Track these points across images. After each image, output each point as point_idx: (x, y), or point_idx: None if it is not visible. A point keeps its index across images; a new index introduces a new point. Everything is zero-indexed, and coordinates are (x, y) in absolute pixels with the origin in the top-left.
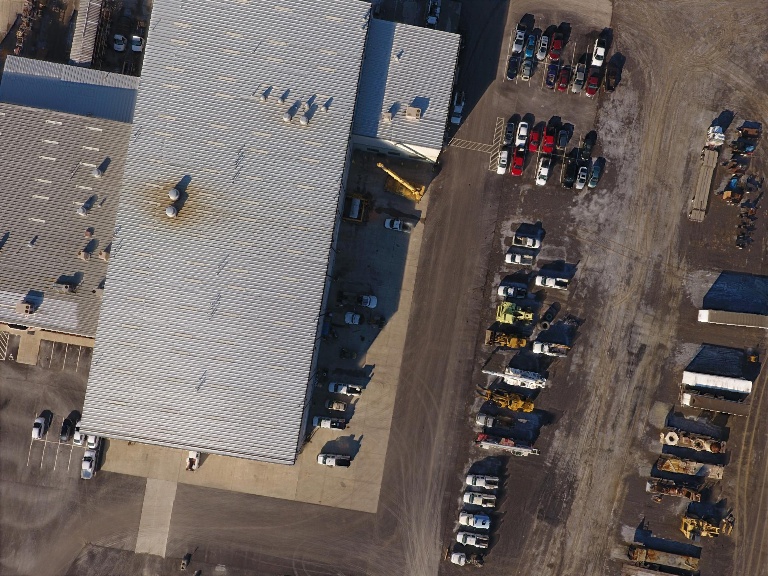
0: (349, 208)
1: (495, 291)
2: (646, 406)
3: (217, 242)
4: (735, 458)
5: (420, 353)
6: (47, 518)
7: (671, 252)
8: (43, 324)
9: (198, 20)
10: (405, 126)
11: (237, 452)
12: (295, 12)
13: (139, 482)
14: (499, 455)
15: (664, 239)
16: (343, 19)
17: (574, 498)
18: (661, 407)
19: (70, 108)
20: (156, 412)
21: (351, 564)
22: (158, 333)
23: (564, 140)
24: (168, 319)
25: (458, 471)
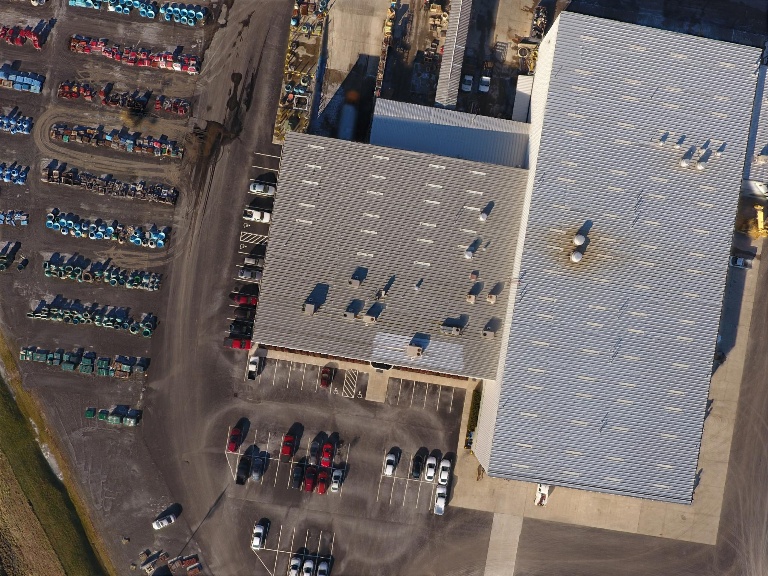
0: None
1: None
2: None
3: (617, 286)
4: None
5: (757, 387)
6: (396, 553)
7: None
8: (430, 366)
9: (598, 67)
10: None
11: (638, 492)
12: (690, 58)
13: (486, 517)
14: None
15: None
16: (736, 65)
17: None
18: None
19: (440, 151)
20: (560, 454)
21: None
22: (562, 376)
23: None
24: (571, 362)
25: None
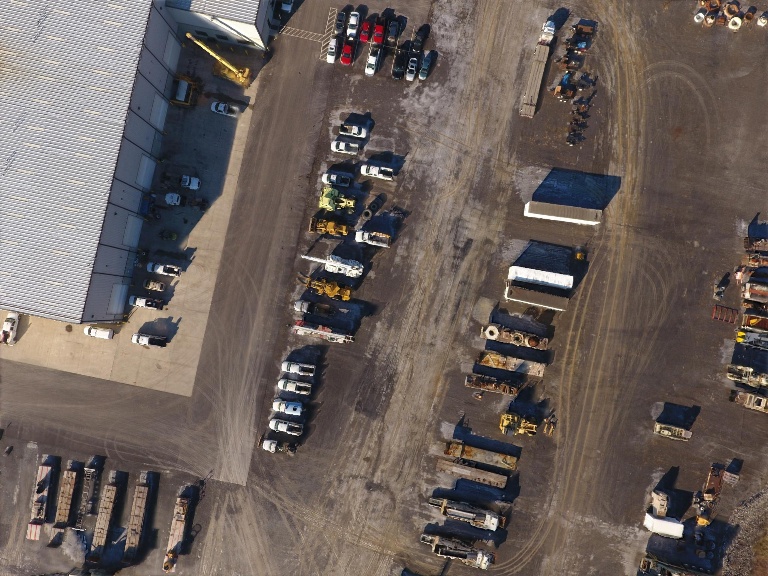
0: (176, 90)
1: (321, 179)
2: (470, 301)
3: (15, 99)
4: (559, 357)
5: (243, 238)
6: None
7: (501, 147)
8: None
9: None
10: (219, 0)
11: (24, 308)
12: None
13: None
14: (318, 344)
15: (495, 134)
16: None
17: (393, 391)
18: (486, 303)
19: None
20: None
21: (163, 447)
22: None
23: (394, 30)
24: None
25: (276, 358)
